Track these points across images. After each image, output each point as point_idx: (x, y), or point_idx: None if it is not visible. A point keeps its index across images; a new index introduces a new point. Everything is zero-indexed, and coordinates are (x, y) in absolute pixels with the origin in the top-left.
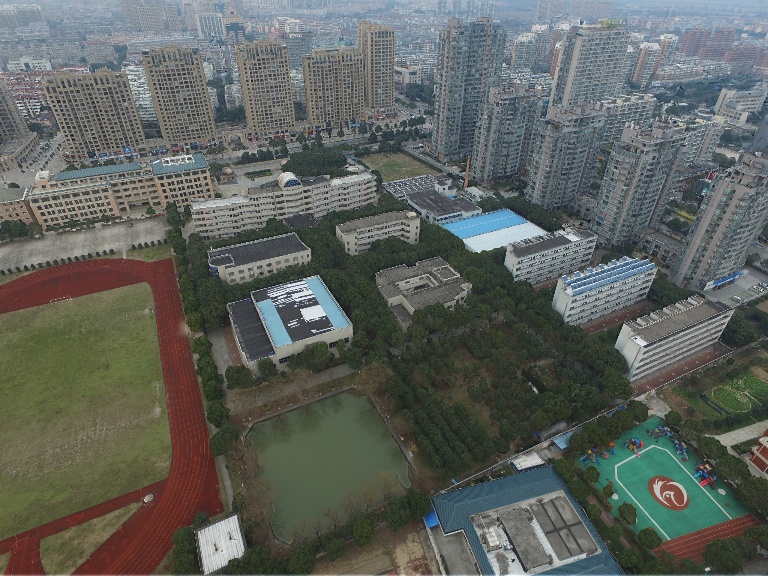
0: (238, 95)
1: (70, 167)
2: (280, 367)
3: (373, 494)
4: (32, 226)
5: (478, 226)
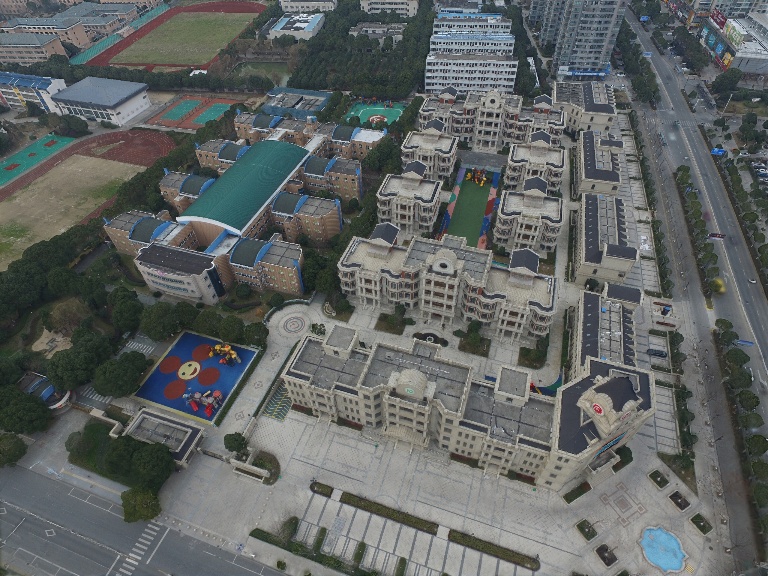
0: None
1: None
2: (272, 45)
3: (251, 71)
4: None
5: None
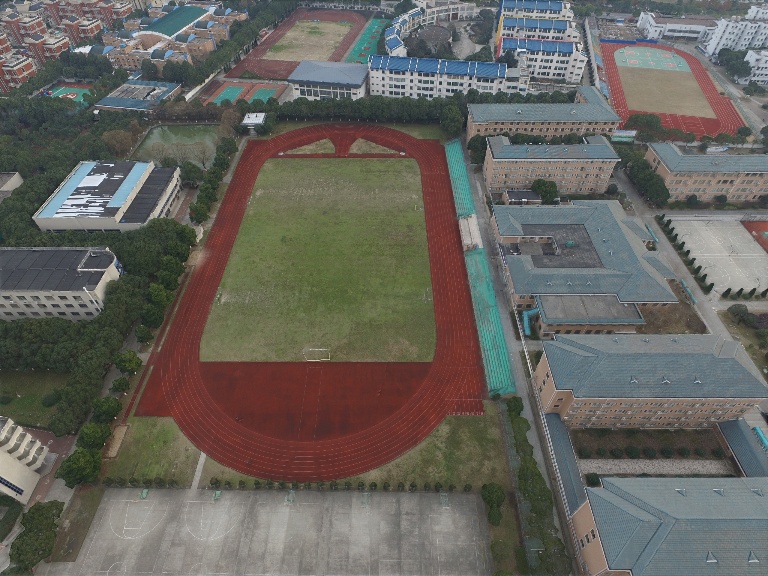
0: None
1: None
2: None
3: (181, 101)
4: None
5: None
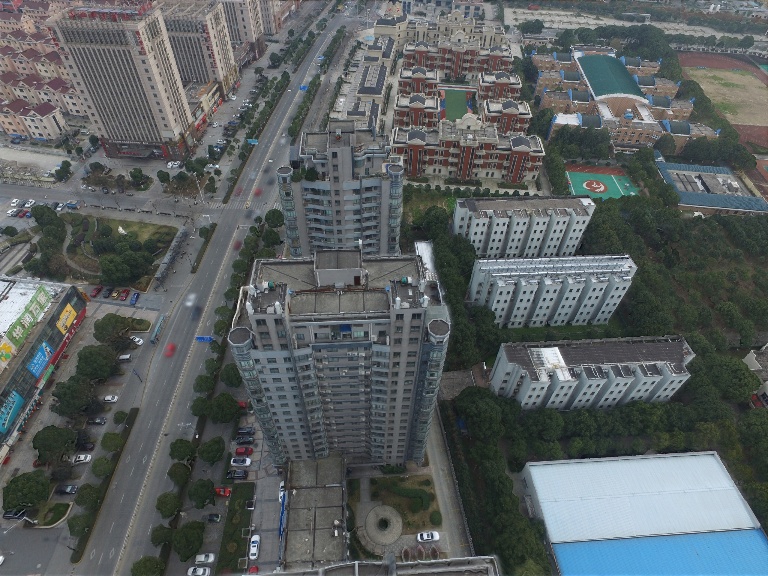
0: None
1: None
2: None
3: None
4: None
5: (702, 574)
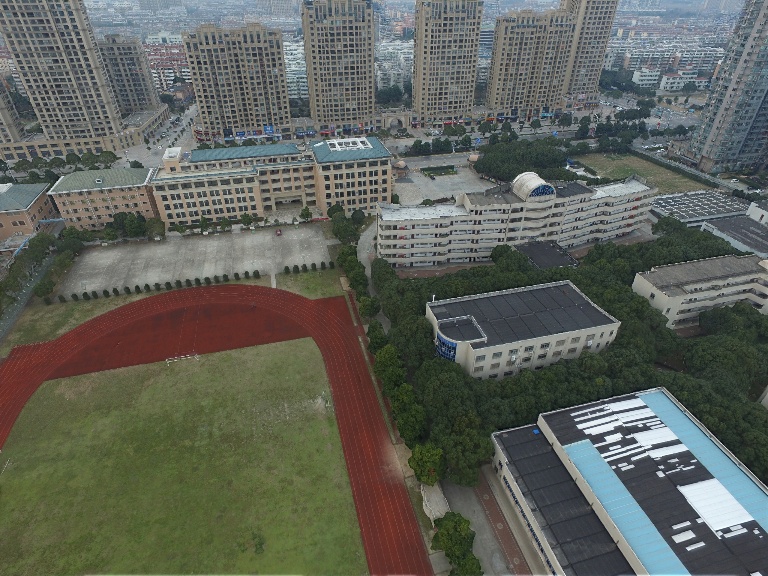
0: (394, 72)
1: (203, 146)
2: None
3: None
4: (152, 223)
5: None
